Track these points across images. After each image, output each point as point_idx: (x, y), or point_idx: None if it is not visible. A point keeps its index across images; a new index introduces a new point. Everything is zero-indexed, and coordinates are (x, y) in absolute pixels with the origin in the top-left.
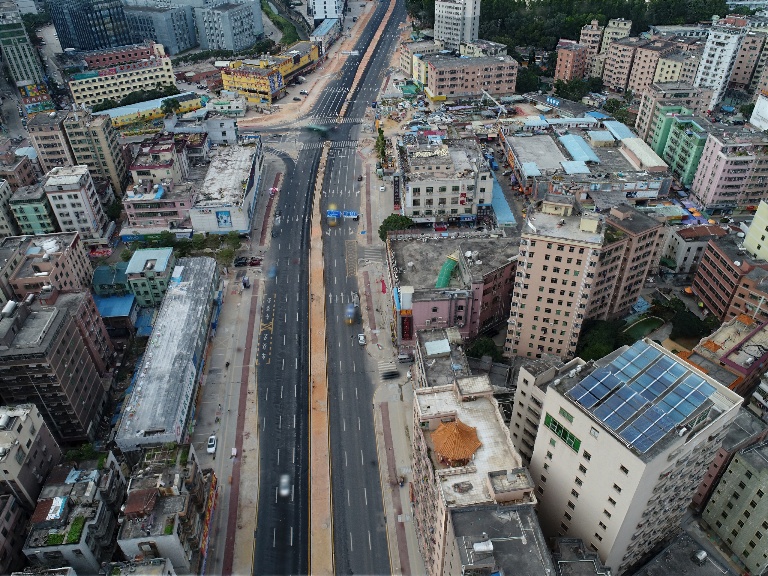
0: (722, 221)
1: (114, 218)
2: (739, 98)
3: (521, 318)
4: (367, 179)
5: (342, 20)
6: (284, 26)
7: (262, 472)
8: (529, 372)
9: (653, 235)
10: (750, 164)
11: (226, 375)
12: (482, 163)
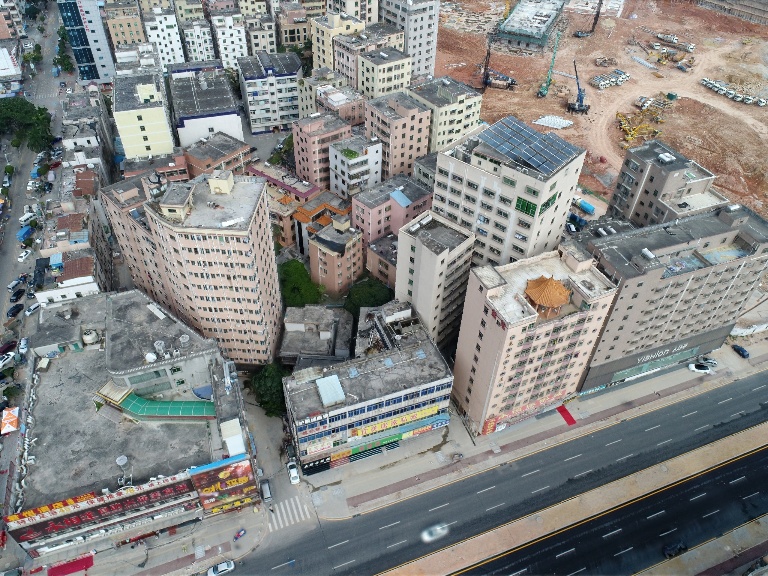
0: (6, 193)
1: None
2: None
3: None
4: None
5: None
6: None
7: None
8: (444, 251)
9: None
10: None
11: None
12: None
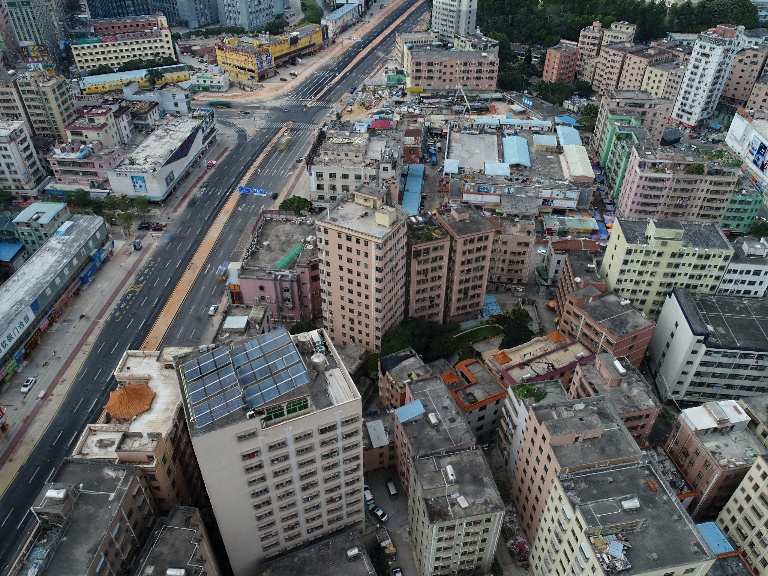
0: None
1: None
2: None
3: (331, 306)
4: None
5: (363, 6)
6: (308, 8)
7: (57, 416)
8: None
9: (484, 240)
10: (667, 182)
11: (76, 326)
12: None
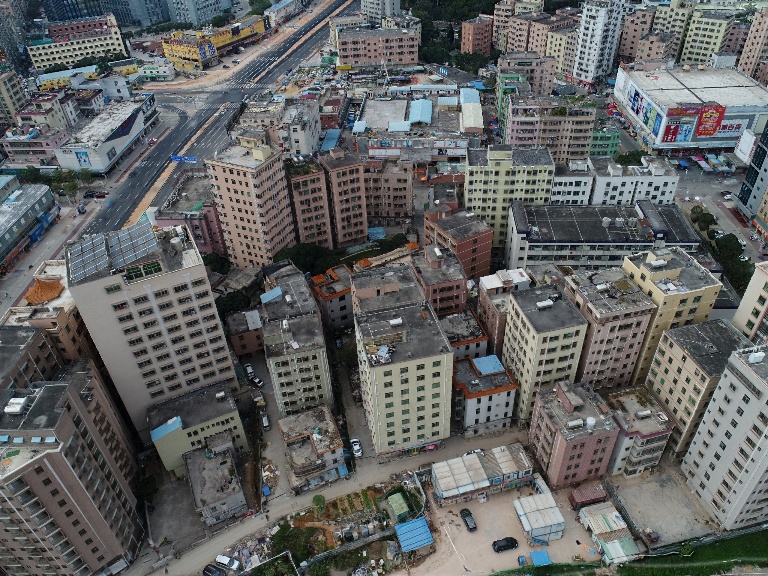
0: None
1: None
2: None
3: (230, 235)
4: None
5: None
6: (255, 2)
7: None
8: None
9: (356, 172)
10: (536, 125)
11: (26, 274)
12: (298, 118)
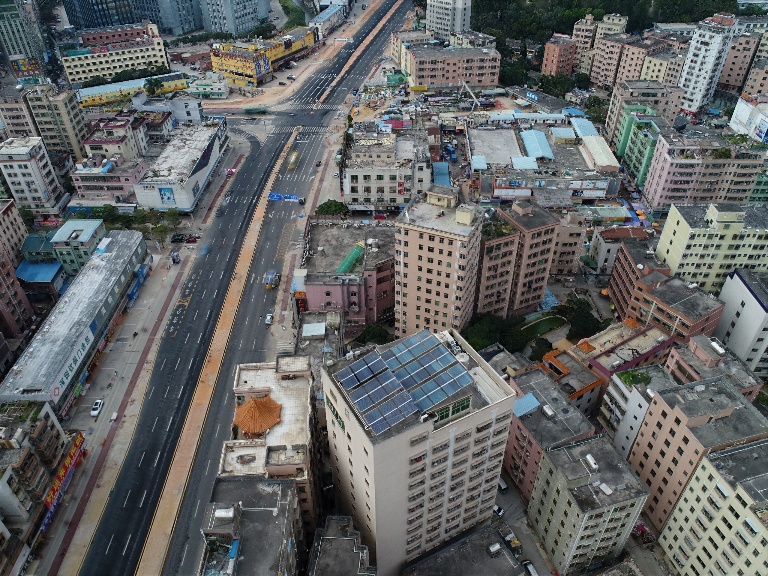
0: None
1: (71, 190)
2: (731, 101)
3: (405, 307)
4: (325, 165)
5: (347, 7)
6: (291, 11)
7: (135, 437)
8: None
9: (550, 232)
10: (696, 168)
11: (131, 344)
12: (422, 153)
